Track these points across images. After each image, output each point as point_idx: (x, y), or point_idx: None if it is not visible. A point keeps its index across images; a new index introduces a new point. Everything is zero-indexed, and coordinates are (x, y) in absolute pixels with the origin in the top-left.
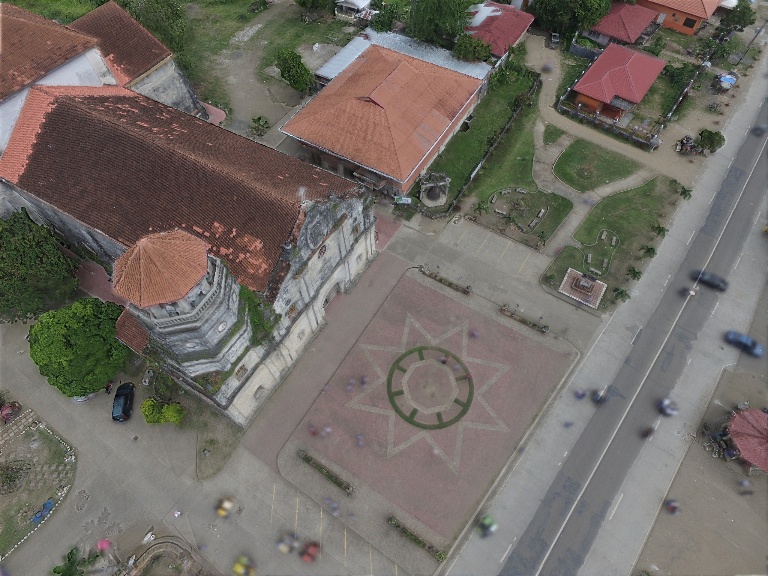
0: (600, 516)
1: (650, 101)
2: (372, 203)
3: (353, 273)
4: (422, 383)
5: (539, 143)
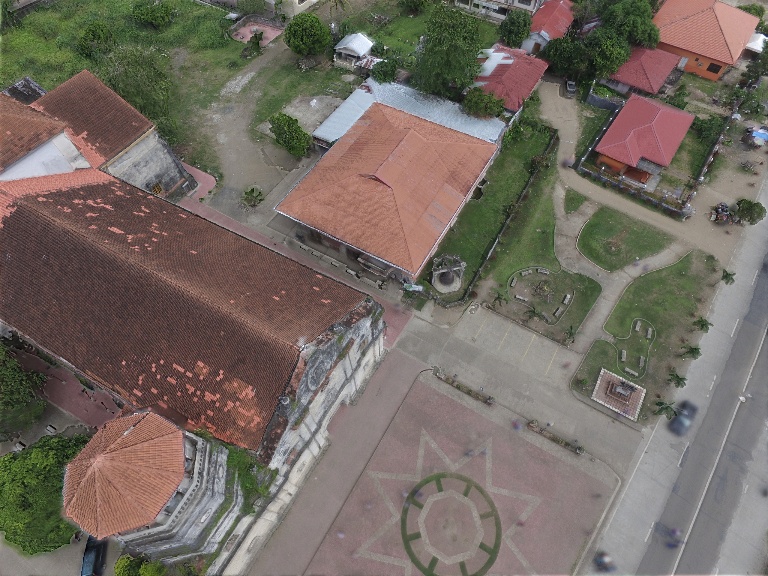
0: None
1: (678, 160)
2: (381, 314)
3: (359, 382)
4: (441, 522)
5: (560, 212)
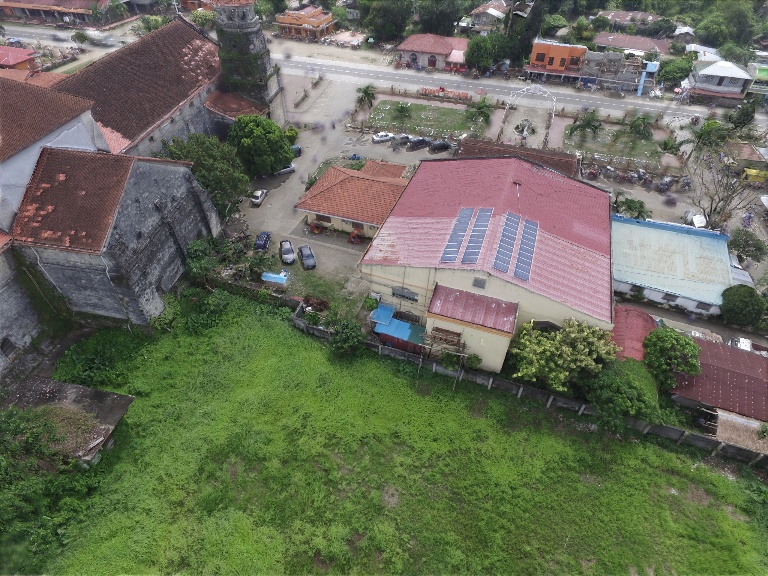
0: (292, 61)
1: None
2: None
3: None
4: None
5: None
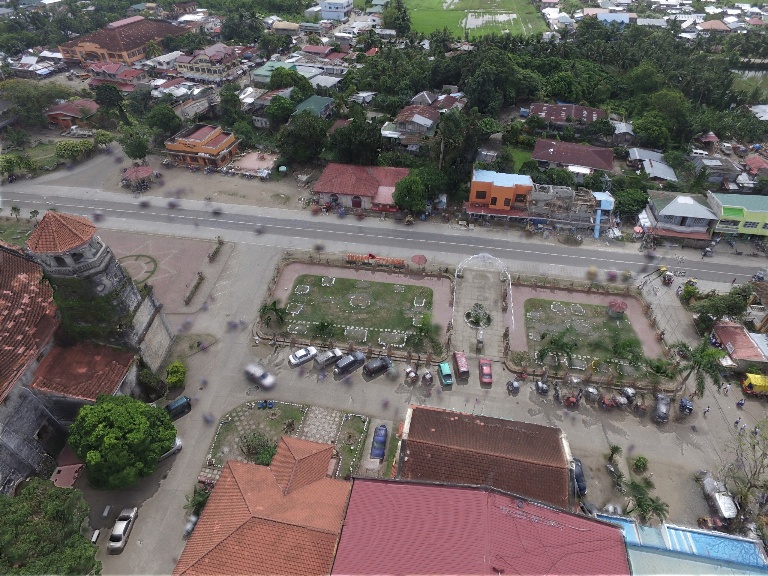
0: None
1: None
2: None
3: None
4: None
5: None
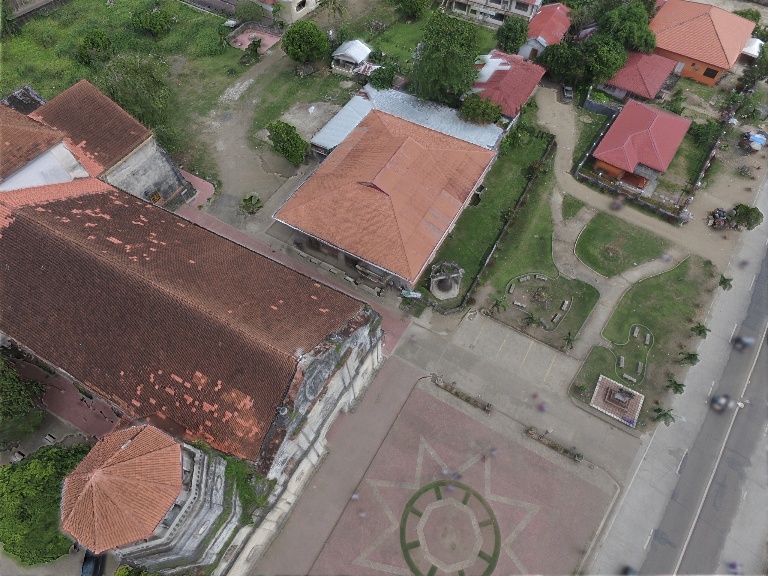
0: None
1: (675, 165)
2: None
3: (358, 390)
4: (440, 531)
5: (557, 217)
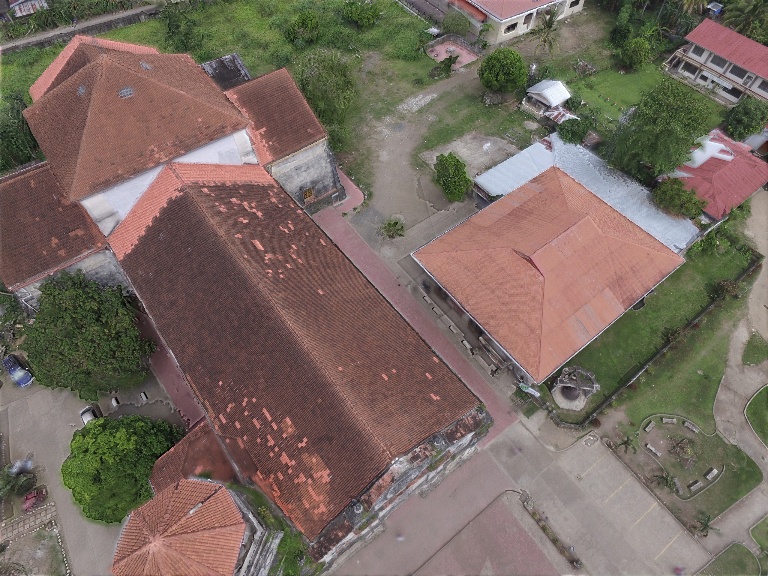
0: None
1: None
2: None
3: None
4: None
5: (735, 359)
